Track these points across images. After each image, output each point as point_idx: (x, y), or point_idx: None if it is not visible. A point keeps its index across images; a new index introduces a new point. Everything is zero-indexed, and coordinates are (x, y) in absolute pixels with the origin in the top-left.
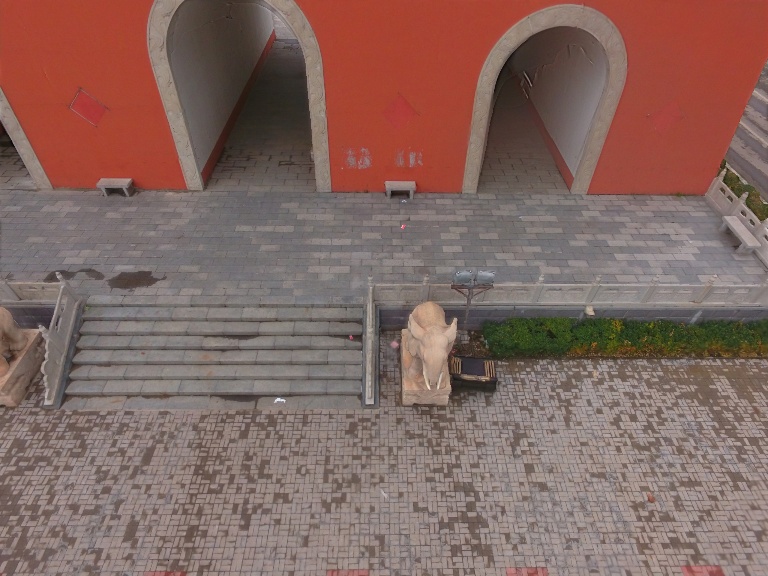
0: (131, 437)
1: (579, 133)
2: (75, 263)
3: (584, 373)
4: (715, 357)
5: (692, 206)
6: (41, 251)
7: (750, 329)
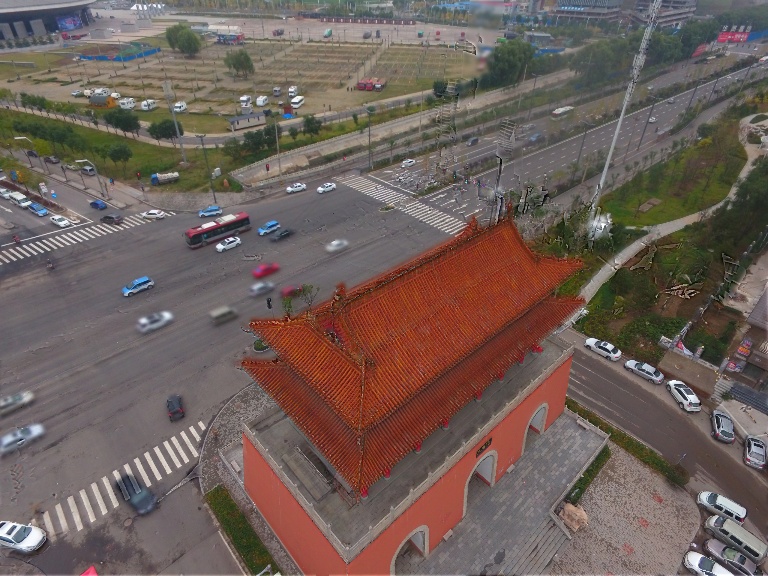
0: None
1: (536, 419)
2: (480, 567)
3: (591, 492)
4: (603, 465)
5: (565, 419)
6: (466, 573)
7: (603, 453)
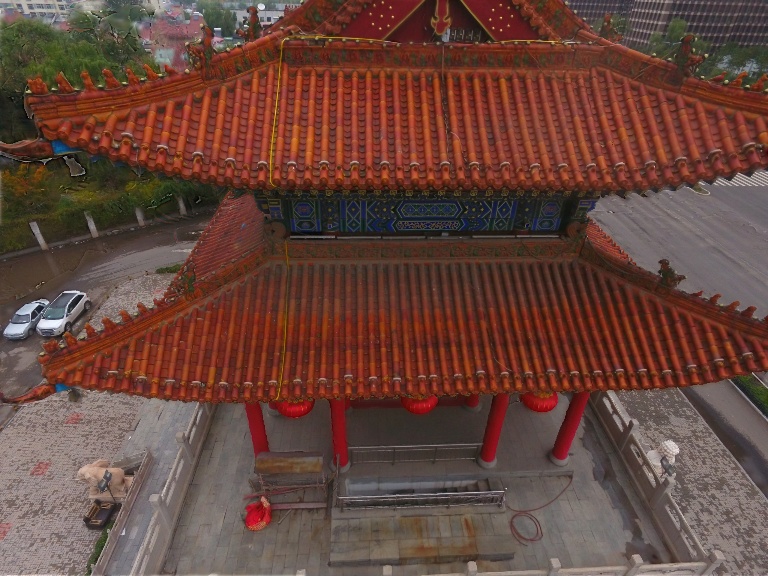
0: (136, 397)
1: None
2: None
3: None
4: None
5: None
6: None
7: None
